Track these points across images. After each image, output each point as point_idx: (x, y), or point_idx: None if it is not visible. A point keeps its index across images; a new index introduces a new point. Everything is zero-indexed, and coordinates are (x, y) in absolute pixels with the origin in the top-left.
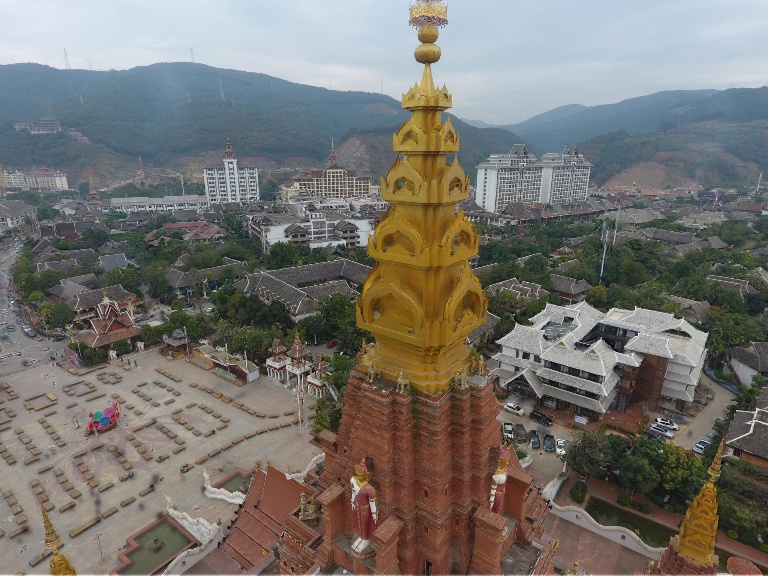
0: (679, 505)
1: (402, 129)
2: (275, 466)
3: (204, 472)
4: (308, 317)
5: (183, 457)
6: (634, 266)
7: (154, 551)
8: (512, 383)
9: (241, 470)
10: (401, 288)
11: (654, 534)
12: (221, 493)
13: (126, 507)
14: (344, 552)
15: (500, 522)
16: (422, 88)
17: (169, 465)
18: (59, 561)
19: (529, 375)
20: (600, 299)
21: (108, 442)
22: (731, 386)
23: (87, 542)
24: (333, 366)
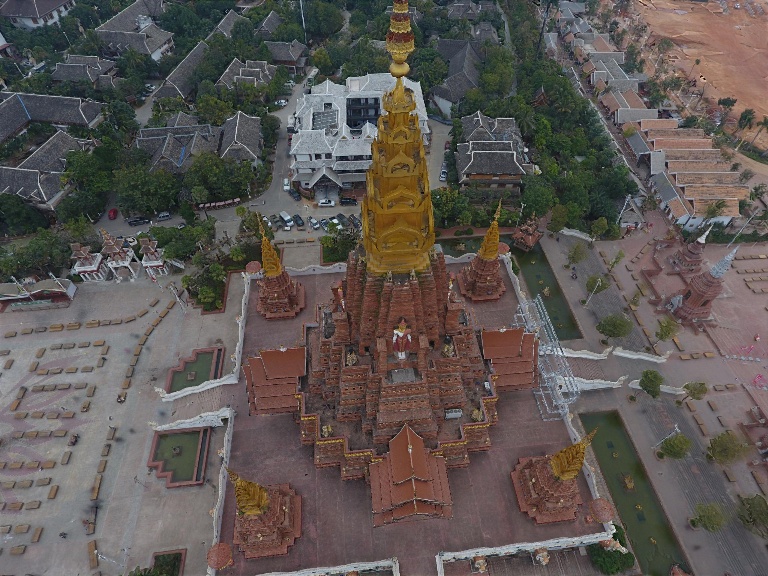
0: (450, 222)
1: (382, 122)
2: (195, 348)
3: (156, 389)
4: (65, 198)
5: (104, 393)
6: (328, 9)
7: (179, 455)
8: (316, 183)
9: (174, 368)
10: (408, 227)
11: (442, 244)
12: (186, 391)
13: (110, 454)
14: (395, 363)
15: (461, 306)
16: (399, 96)
17: (100, 406)
18: (242, 483)
19: (328, 172)
20: (326, 64)
21: (1, 434)
22: (438, 117)
23: (114, 491)
24: (157, 240)
